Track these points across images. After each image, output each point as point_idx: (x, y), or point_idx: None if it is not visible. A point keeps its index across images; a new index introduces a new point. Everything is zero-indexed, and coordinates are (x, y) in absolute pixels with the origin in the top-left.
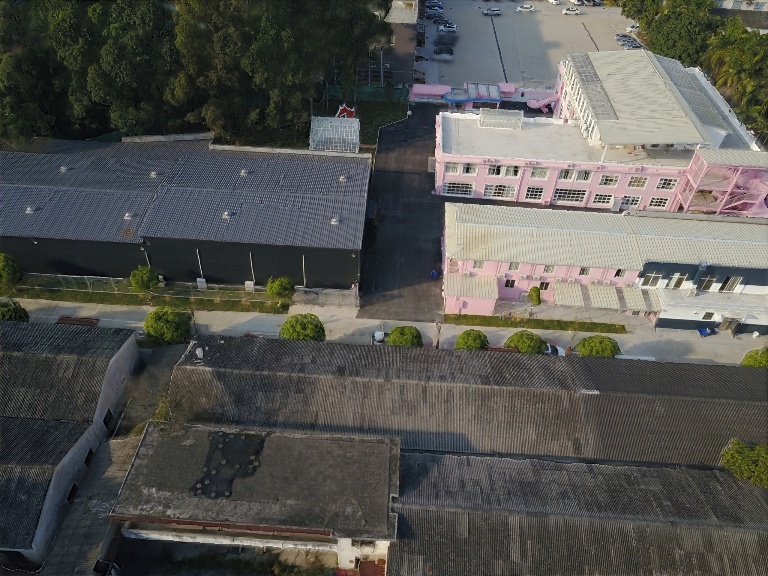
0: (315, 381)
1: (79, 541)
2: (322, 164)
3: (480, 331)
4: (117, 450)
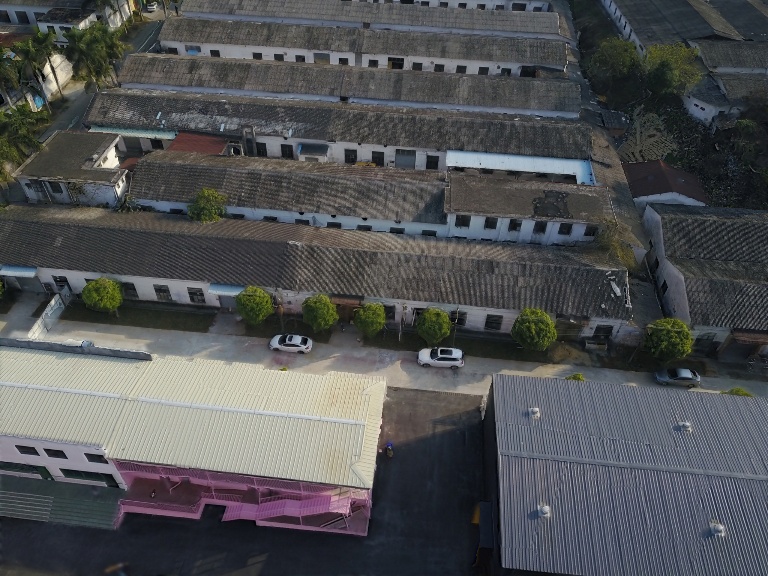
0: None
1: None
2: (593, 569)
3: (362, 316)
4: (633, 238)
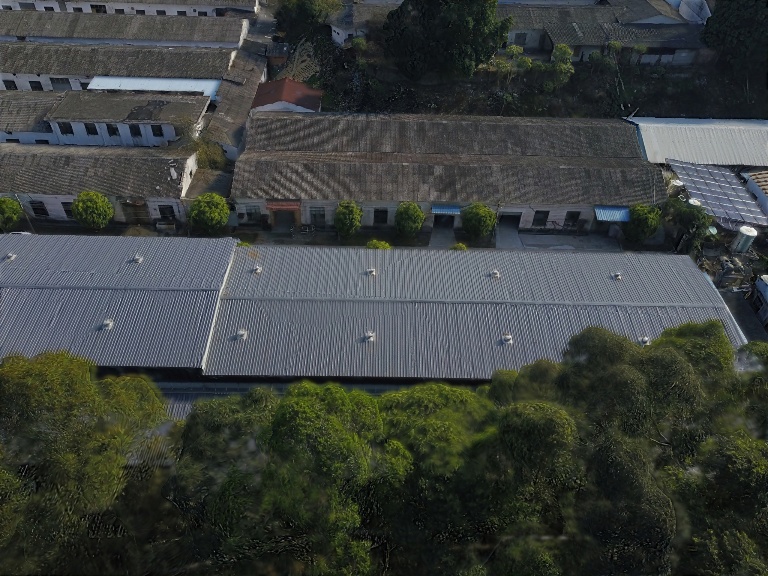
0: (88, 155)
1: (232, 110)
2: None
3: None
4: (224, 137)
